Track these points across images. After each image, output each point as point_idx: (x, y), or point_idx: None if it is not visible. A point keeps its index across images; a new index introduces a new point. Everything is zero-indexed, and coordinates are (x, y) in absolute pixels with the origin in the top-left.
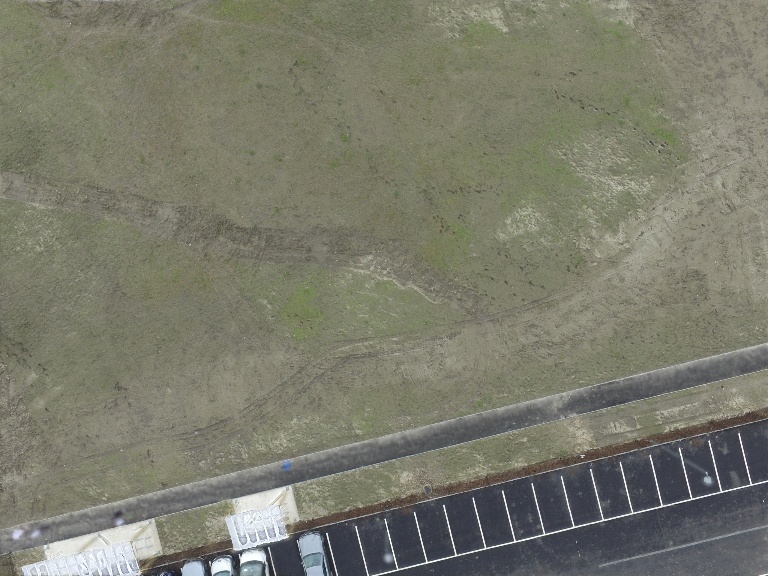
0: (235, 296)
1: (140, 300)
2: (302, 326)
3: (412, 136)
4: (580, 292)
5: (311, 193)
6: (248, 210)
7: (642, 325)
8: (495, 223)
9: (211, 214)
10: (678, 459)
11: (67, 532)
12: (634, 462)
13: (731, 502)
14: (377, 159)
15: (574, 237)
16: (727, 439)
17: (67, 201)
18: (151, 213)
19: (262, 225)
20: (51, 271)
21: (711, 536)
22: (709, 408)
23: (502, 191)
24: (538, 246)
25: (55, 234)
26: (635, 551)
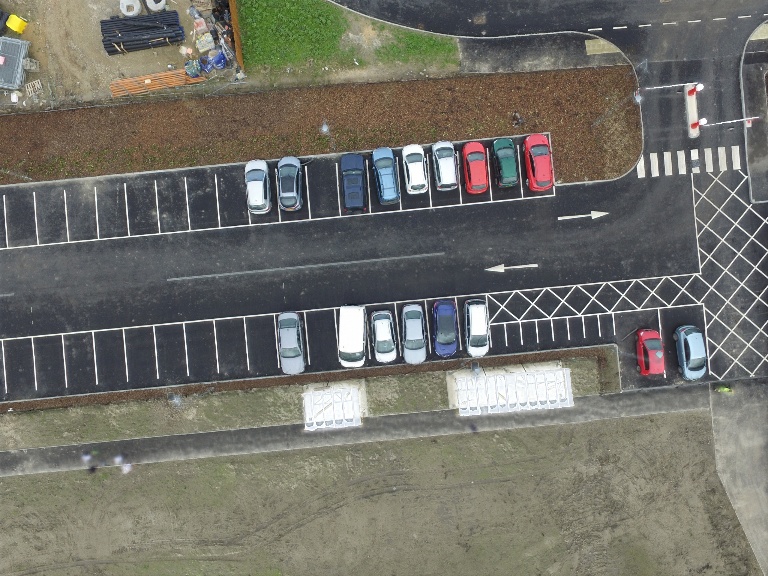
0: None
1: None
2: None
3: None
4: None
5: None
6: None
7: None
8: None
9: None
10: None
11: None
12: None
13: None
14: None
15: None
16: None
17: None
18: None
19: None
20: None
21: None
22: None
23: None
24: None
25: None
26: None
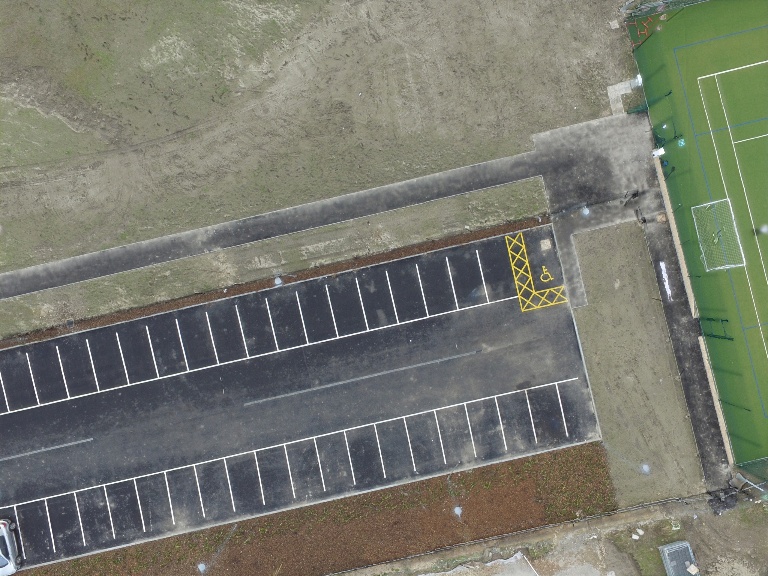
0: None
1: None
2: None
3: None
4: (224, 122)
5: None
6: None
7: (287, 158)
8: (140, 51)
9: None
10: (324, 296)
11: None
12: (280, 298)
13: (378, 341)
14: None
15: (218, 66)
16: (374, 276)
17: None
18: None
19: None
20: None
21: (357, 376)
22: (354, 244)
23: (147, 19)
24: (183, 75)
25: None
26: (280, 390)
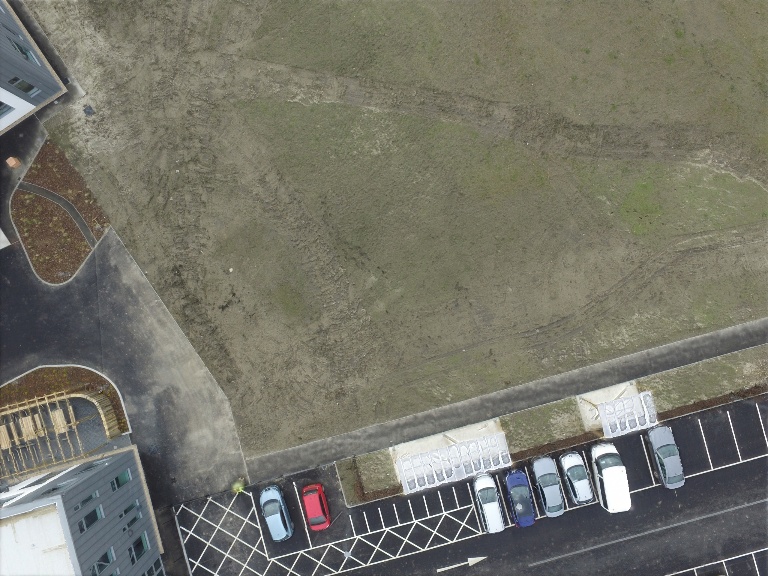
0: (573, 193)
1: (478, 200)
2: (641, 221)
3: (746, 30)
4: None
5: (647, 89)
6: (585, 108)
7: None
8: None
9: (548, 113)
10: None
11: (412, 433)
12: None
13: None
14: (712, 54)
15: None
16: None
17: (403, 104)
18: (487, 113)
19: (599, 122)
20: (388, 174)
21: None
22: None
23: None
24: None
25: (391, 137)
26: None
